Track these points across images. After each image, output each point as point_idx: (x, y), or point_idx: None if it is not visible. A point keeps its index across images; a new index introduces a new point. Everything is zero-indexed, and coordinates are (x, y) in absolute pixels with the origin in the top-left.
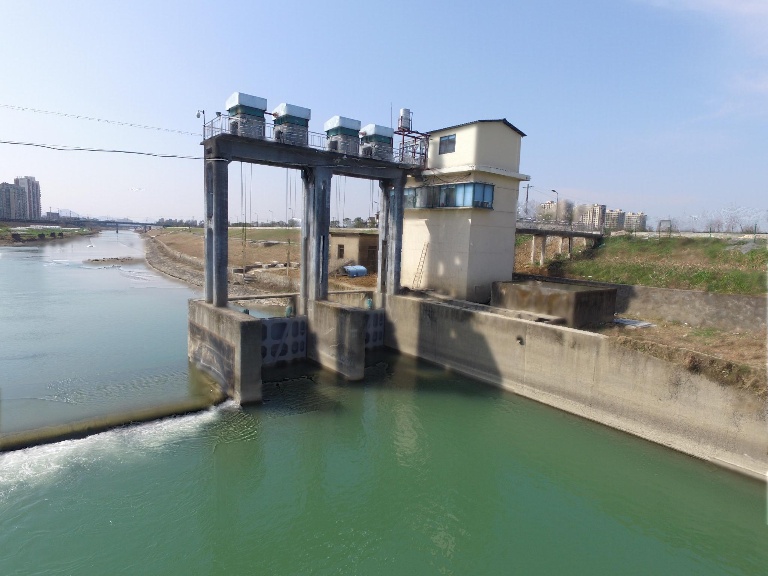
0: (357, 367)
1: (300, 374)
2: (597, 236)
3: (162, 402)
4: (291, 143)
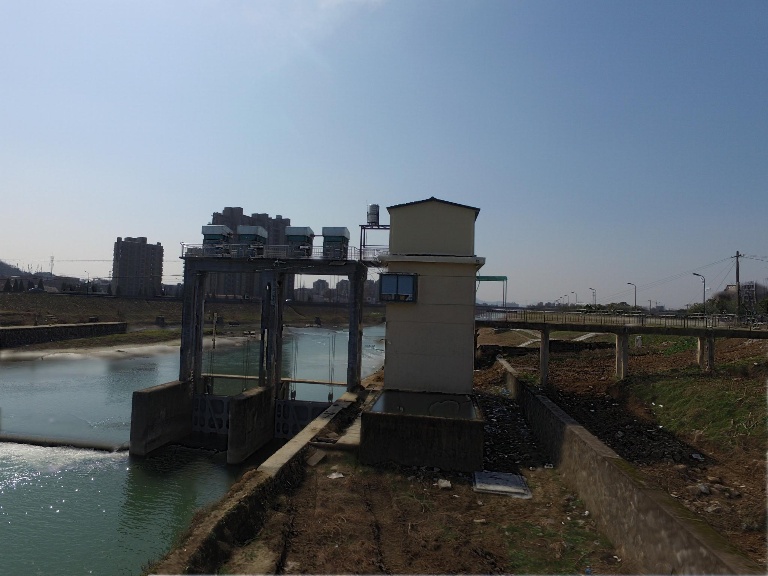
0: (230, 451)
1: (215, 447)
2: None
3: (105, 439)
4: (232, 256)
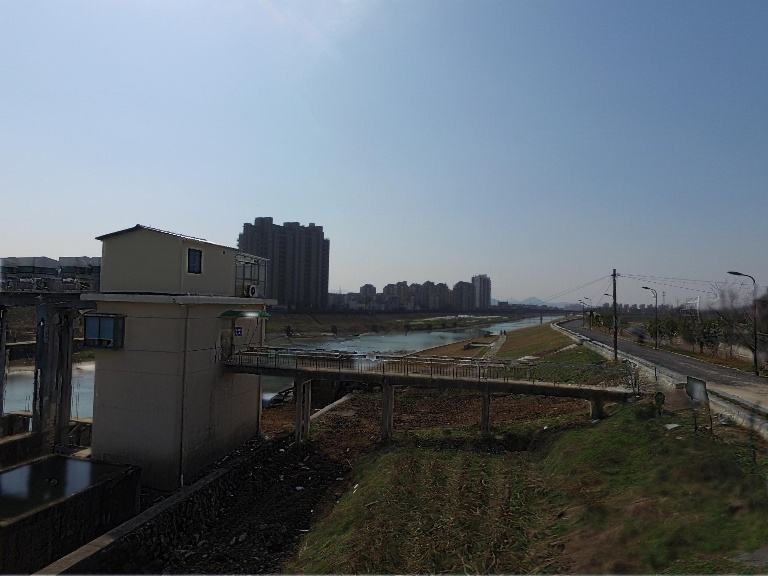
0: None
1: None
2: (604, 396)
3: None
4: (5, 290)
